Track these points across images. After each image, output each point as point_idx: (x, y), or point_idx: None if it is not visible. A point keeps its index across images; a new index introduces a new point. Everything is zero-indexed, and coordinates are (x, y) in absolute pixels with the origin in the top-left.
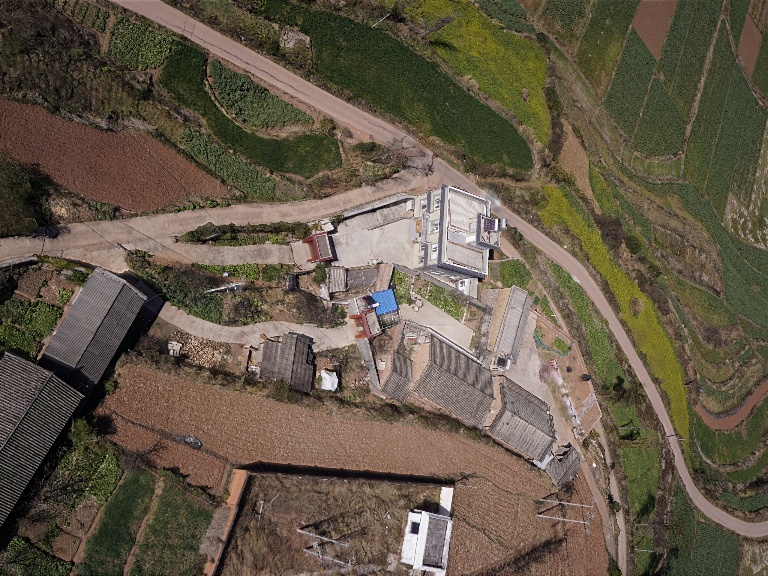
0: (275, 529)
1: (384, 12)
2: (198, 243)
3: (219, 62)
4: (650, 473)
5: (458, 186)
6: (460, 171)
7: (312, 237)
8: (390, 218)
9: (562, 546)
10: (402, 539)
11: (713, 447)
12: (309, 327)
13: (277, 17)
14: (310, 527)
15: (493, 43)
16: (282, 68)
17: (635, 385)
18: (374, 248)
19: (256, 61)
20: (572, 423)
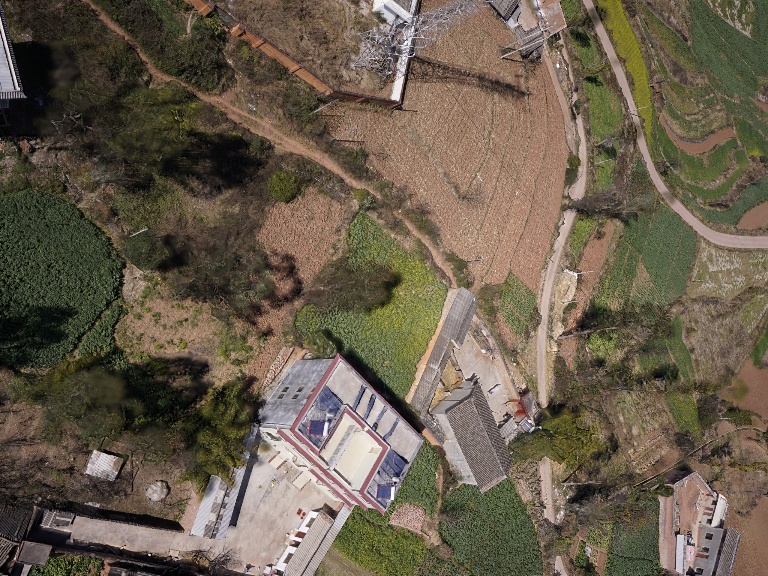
0: None
1: None
2: None
3: None
4: (612, 129)
5: None
6: None
7: None
8: None
9: (524, 99)
10: None
11: (675, 159)
12: None
13: None
14: None
15: None
16: None
17: (601, 53)
18: None
19: None
20: (538, 18)
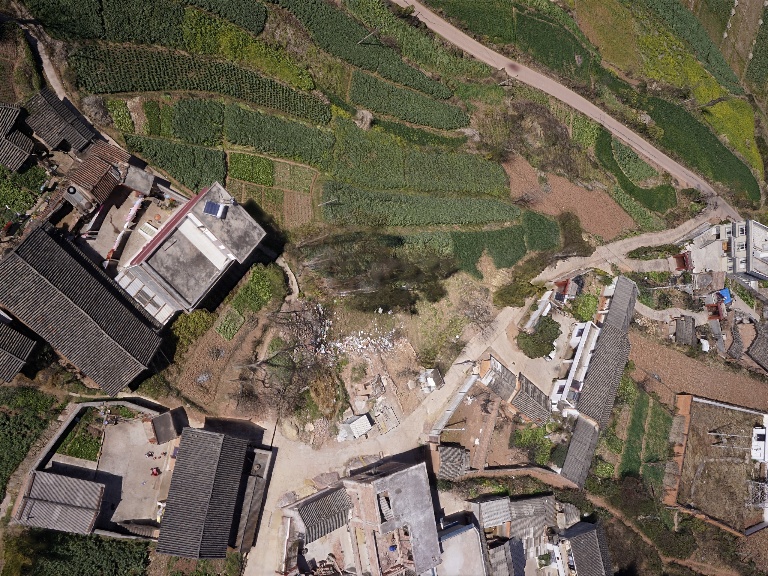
0: (698, 432)
1: (680, 93)
2: (633, 259)
3: (617, 139)
4: None
5: (730, 216)
6: (730, 205)
7: (684, 254)
8: (706, 240)
9: None
10: (751, 445)
11: None
12: (688, 312)
13: (637, 105)
14: (712, 432)
15: (726, 106)
16: (644, 140)
17: None
18: (703, 260)
19: (632, 137)
20: None
